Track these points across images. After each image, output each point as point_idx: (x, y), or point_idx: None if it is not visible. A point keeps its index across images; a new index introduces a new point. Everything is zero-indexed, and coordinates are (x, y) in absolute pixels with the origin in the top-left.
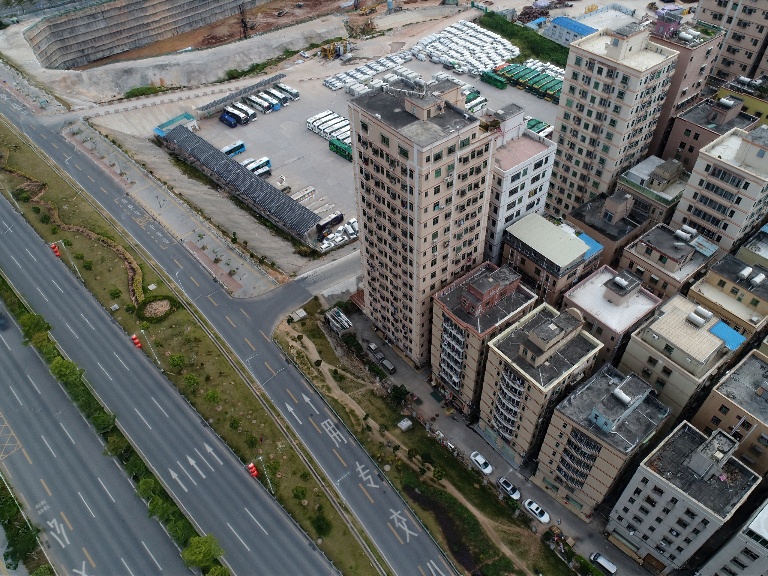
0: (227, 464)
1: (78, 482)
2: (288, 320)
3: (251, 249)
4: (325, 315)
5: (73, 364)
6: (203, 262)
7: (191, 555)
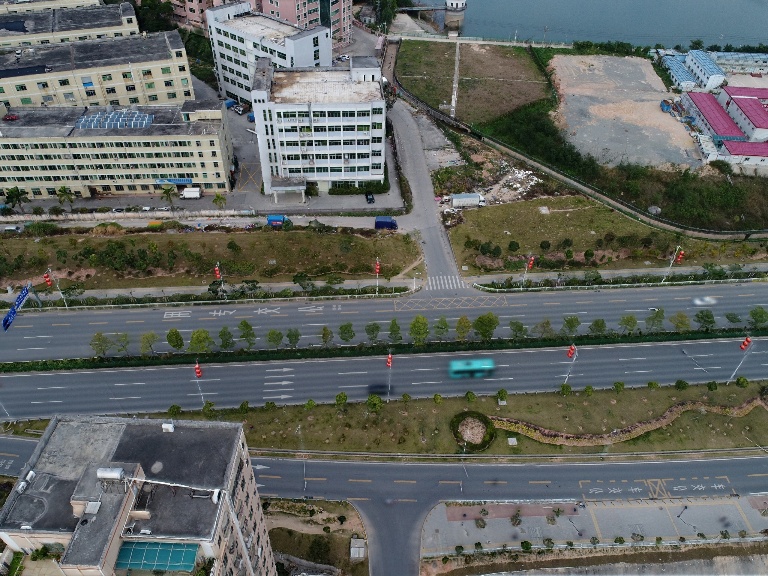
0: (260, 400)
1: (336, 326)
2: (342, 516)
3: (518, 575)
4: (331, 574)
5: (421, 333)
6: (524, 506)
7: (199, 331)
